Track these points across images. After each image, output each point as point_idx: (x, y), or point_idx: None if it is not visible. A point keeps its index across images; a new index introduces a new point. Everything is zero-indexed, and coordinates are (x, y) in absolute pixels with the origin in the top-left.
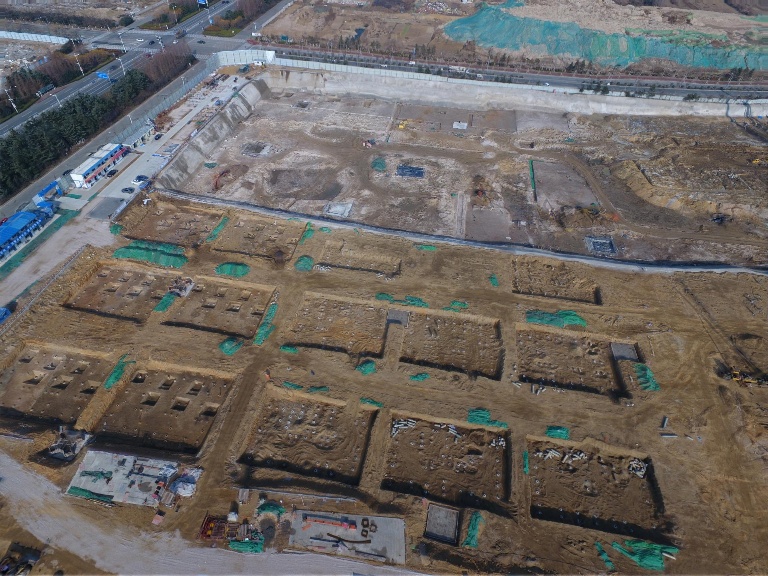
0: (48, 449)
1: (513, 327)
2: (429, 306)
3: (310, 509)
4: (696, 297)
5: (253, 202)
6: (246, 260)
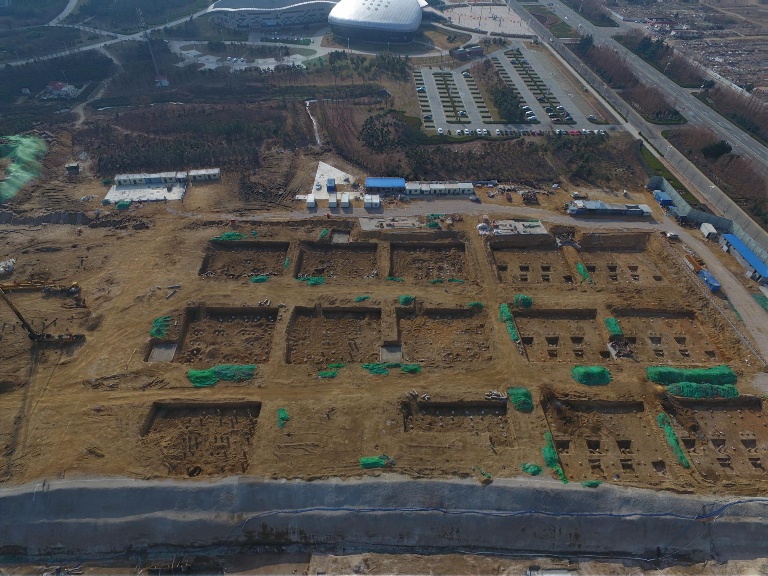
0: (571, 233)
1: (272, 357)
2: (361, 365)
3: (413, 228)
4: (6, 443)
5: (713, 568)
6: (589, 390)
